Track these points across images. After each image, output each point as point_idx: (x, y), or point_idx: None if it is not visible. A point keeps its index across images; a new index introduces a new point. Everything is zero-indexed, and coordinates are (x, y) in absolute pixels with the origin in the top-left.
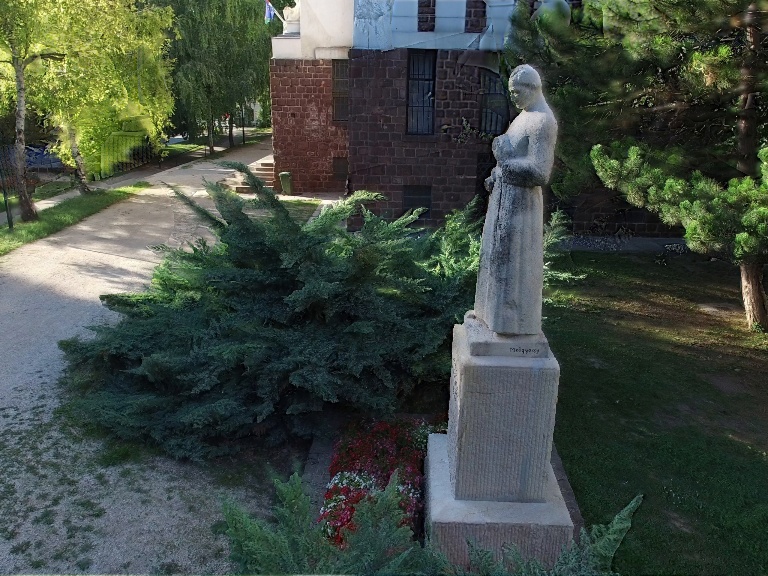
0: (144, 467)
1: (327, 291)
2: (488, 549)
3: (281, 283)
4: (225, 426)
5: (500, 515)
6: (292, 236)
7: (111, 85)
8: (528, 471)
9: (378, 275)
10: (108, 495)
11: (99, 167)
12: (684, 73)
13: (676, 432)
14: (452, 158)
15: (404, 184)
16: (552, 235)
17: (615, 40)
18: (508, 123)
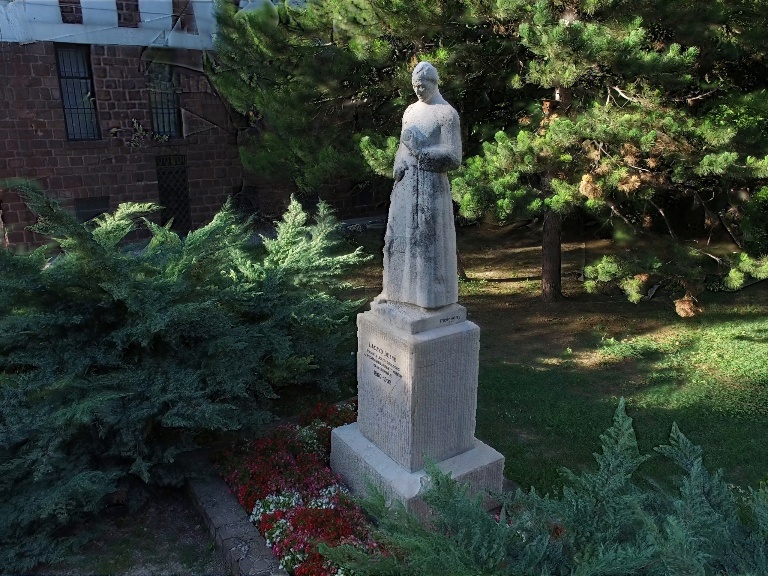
0: None
1: (198, 312)
2: None
3: (84, 322)
4: (90, 505)
5: None
6: (107, 262)
7: None
8: (463, 425)
9: (202, 289)
10: None
11: None
12: (398, 72)
13: None
14: (127, 164)
15: (75, 197)
16: (326, 225)
17: (343, 41)
18: (181, 123)
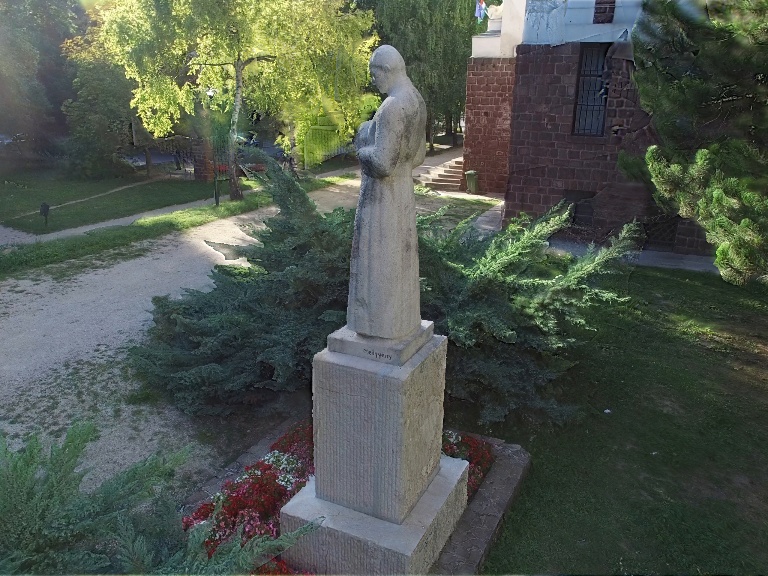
0: (154, 411)
1: (293, 275)
2: (331, 555)
3: None
4: (212, 388)
5: (345, 523)
6: (303, 221)
7: (308, 83)
8: (380, 485)
9: None
10: (111, 426)
11: (303, 157)
12: None
13: (699, 503)
14: None
15: (565, 188)
16: (615, 249)
17: (724, 21)
18: None
